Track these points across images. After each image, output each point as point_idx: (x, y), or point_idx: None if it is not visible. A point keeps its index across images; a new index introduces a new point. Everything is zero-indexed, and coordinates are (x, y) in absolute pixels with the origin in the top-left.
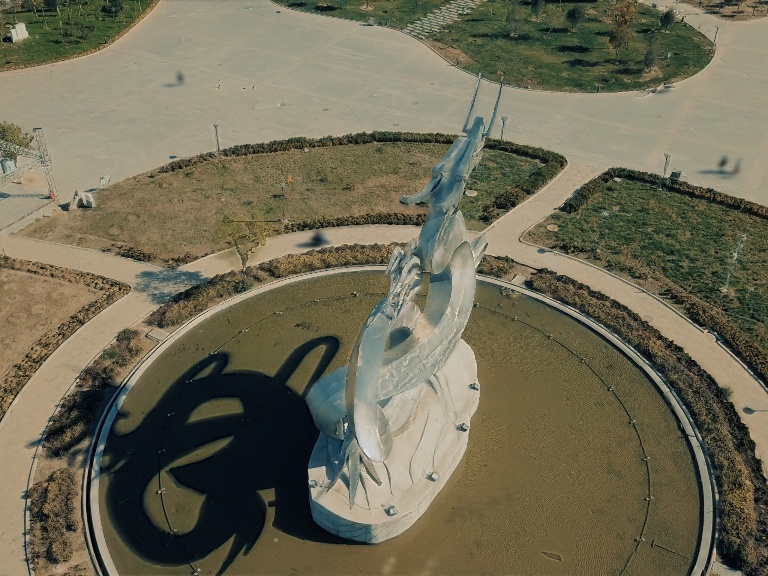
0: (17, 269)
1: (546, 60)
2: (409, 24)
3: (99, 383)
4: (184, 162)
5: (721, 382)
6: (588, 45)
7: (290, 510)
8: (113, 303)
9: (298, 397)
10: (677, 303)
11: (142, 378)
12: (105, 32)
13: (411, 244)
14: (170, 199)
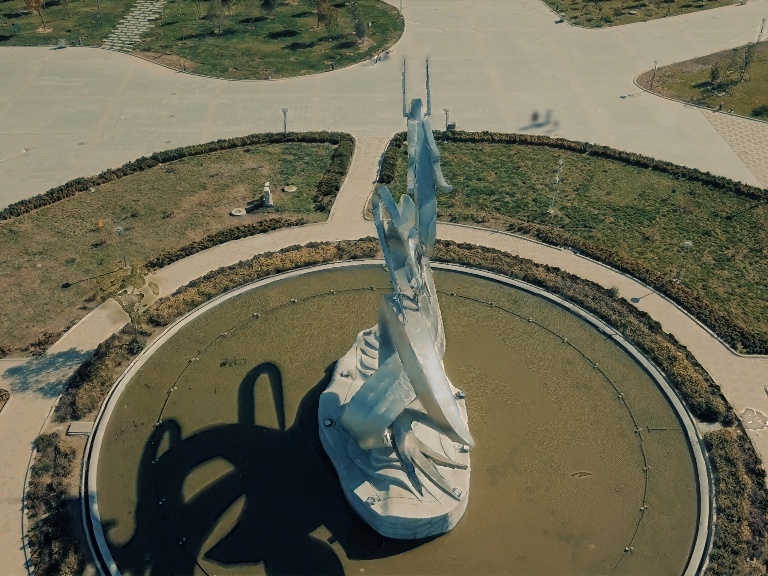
0: None
1: (266, 49)
2: (104, 39)
3: (56, 503)
4: None
5: (602, 285)
6: (294, 28)
7: None
8: None
9: (278, 432)
10: (526, 233)
11: (99, 479)
12: None
13: (416, 233)
14: None
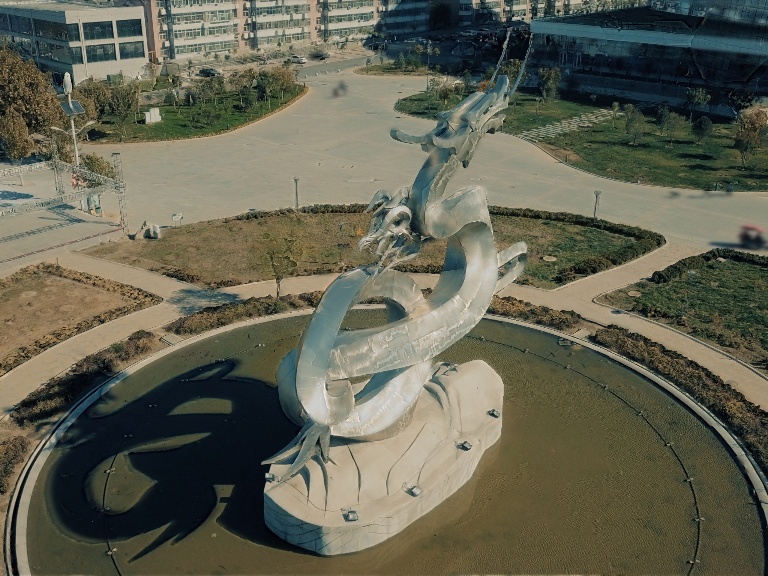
0: (64, 277)
1: (663, 163)
2: (525, 131)
3: (93, 370)
4: (260, 213)
5: None
6: (713, 154)
7: (246, 513)
8: (140, 310)
9: None
10: None
11: (139, 372)
12: (231, 122)
13: (401, 191)
14: (235, 239)
